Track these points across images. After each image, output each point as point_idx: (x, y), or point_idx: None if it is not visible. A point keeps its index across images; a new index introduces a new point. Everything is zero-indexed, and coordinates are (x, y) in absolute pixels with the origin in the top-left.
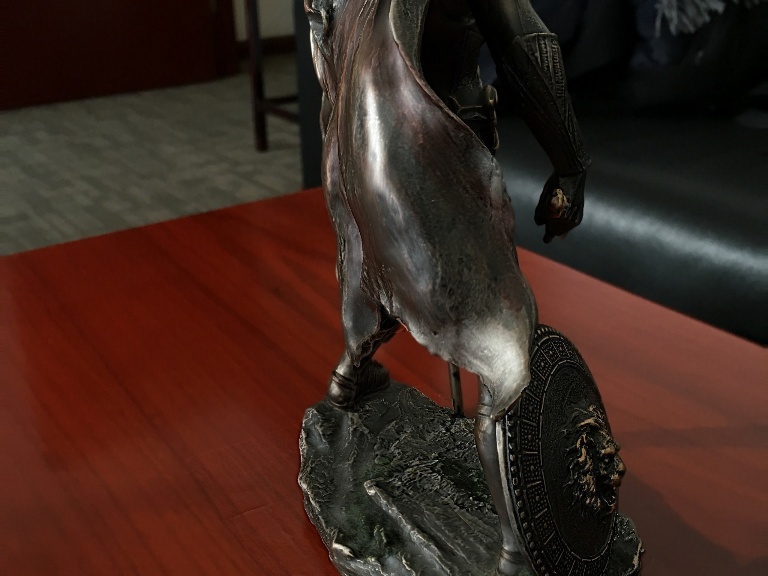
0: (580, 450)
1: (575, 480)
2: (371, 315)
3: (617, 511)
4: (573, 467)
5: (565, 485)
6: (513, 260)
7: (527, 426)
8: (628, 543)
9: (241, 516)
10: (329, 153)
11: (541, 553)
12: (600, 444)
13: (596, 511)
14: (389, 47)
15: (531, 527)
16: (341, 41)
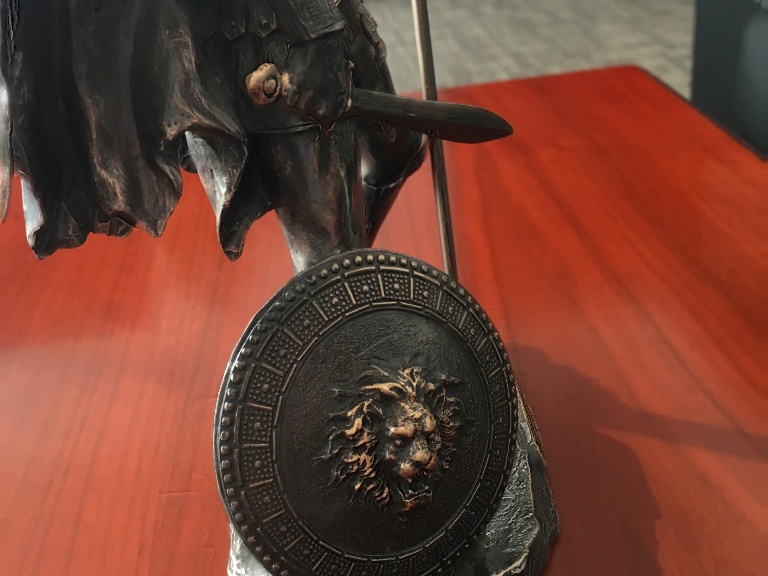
0: (353, 420)
1: (335, 455)
2: (34, 201)
3: (494, 512)
4: (334, 438)
5: (316, 458)
6: (4, 148)
7: (267, 372)
8: (503, 556)
9: (205, 401)
10: (9, 1)
11: (256, 530)
12: (393, 419)
13: (381, 502)
14: None
15: (240, 495)
16: None
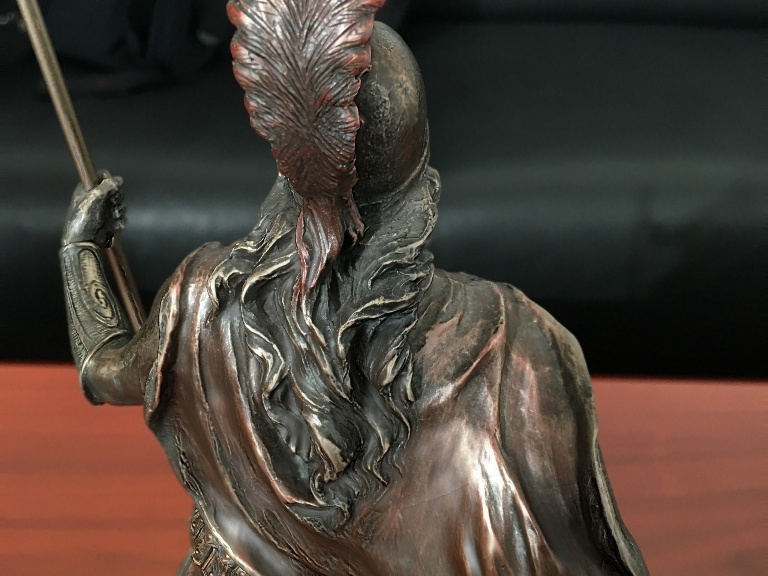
0: None
1: None
2: None
3: None
4: None
5: None
6: None
7: None
8: None
9: None
10: None
11: None
12: None
13: None
14: (598, 574)
15: None
16: (383, 528)
